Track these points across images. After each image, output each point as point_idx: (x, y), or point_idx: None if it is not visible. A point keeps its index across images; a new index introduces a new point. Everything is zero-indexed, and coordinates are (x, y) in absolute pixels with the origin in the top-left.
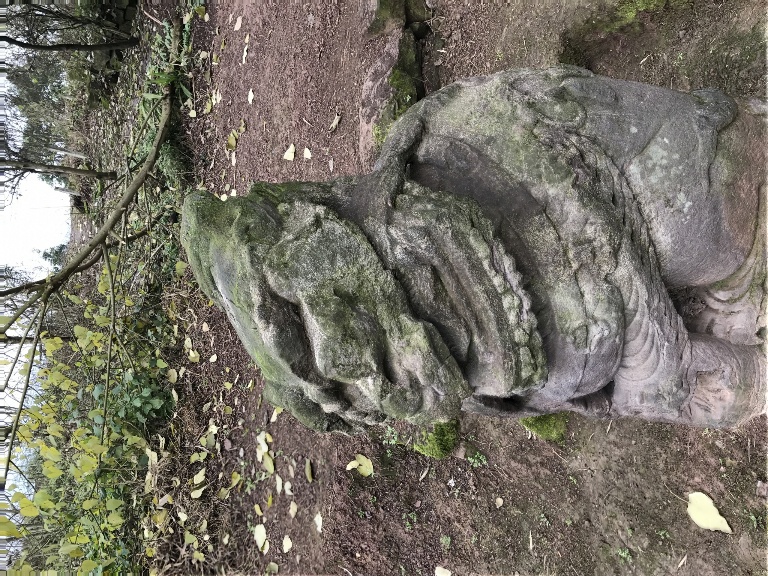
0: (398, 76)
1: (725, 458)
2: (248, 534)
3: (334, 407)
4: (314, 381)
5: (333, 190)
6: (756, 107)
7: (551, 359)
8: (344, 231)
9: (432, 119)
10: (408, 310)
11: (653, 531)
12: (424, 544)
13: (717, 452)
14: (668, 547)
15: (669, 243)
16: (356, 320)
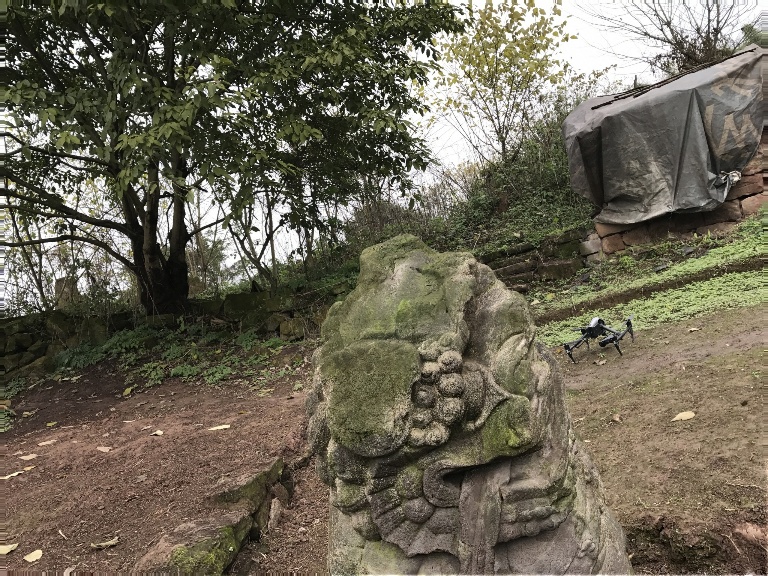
0: (230, 532)
1: None
2: None
3: (458, 356)
4: (465, 326)
5: None
6: None
7: None
8: None
9: None
10: None
11: None
12: None
13: None
14: None
15: None
16: None
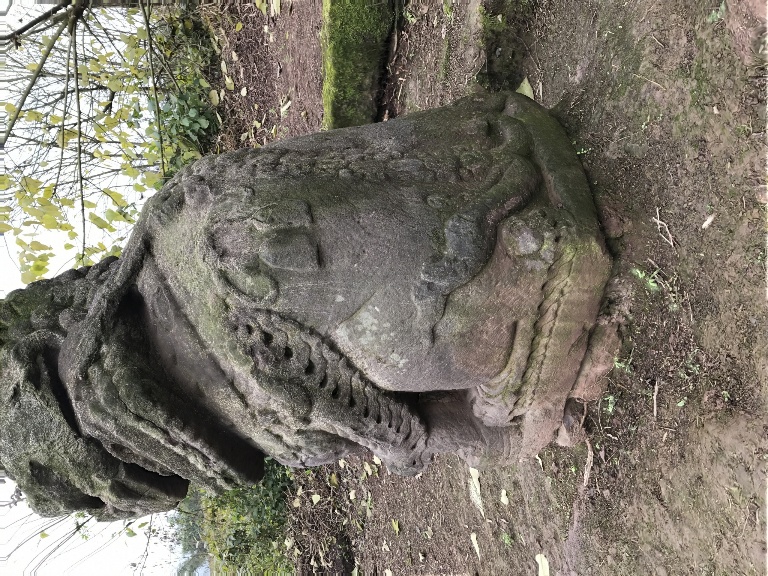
0: None
1: None
2: None
3: None
4: None
5: (59, 320)
6: (524, 245)
7: None
8: (39, 405)
9: (156, 237)
10: (102, 467)
11: None
12: None
13: None
14: None
15: (388, 384)
16: (45, 492)
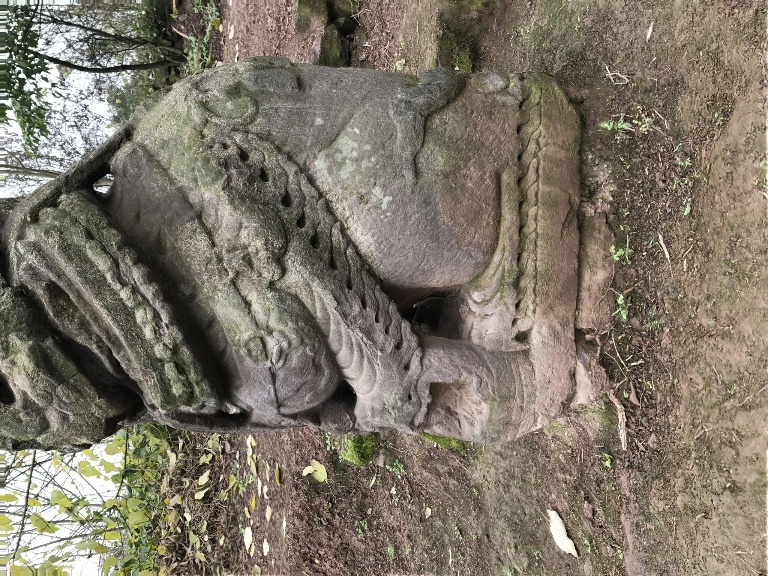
0: None
1: (565, 474)
2: (240, 536)
3: None
4: None
5: None
6: (492, 84)
7: (236, 373)
8: None
9: (138, 125)
10: (26, 328)
11: (531, 550)
12: (375, 553)
13: (562, 467)
14: (542, 569)
15: (371, 243)
16: None
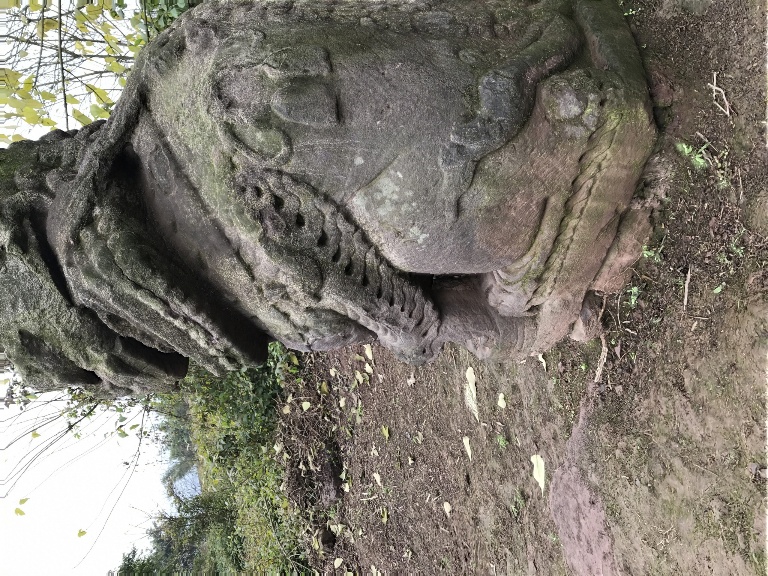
0: None
1: None
2: None
3: None
4: None
5: (46, 180)
6: (565, 107)
7: None
8: (27, 270)
9: (153, 89)
10: (97, 339)
11: None
12: None
13: None
14: None
15: (404, 262)
16: (36, 363)
